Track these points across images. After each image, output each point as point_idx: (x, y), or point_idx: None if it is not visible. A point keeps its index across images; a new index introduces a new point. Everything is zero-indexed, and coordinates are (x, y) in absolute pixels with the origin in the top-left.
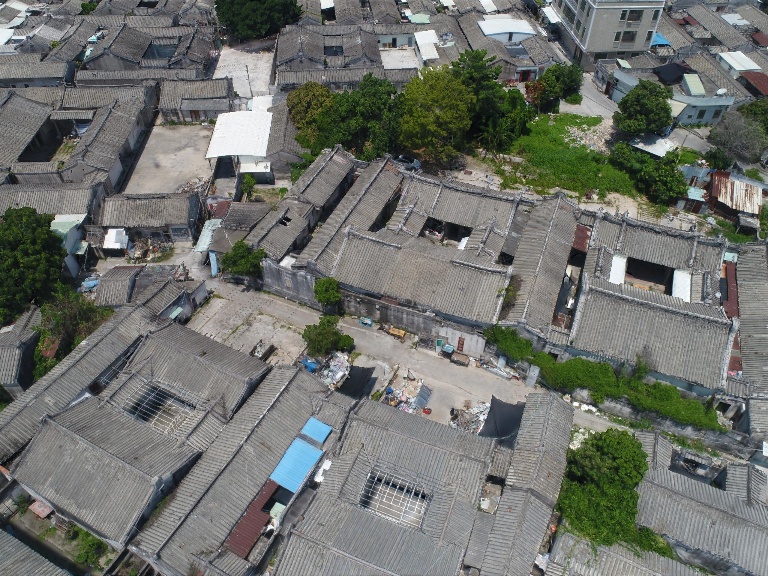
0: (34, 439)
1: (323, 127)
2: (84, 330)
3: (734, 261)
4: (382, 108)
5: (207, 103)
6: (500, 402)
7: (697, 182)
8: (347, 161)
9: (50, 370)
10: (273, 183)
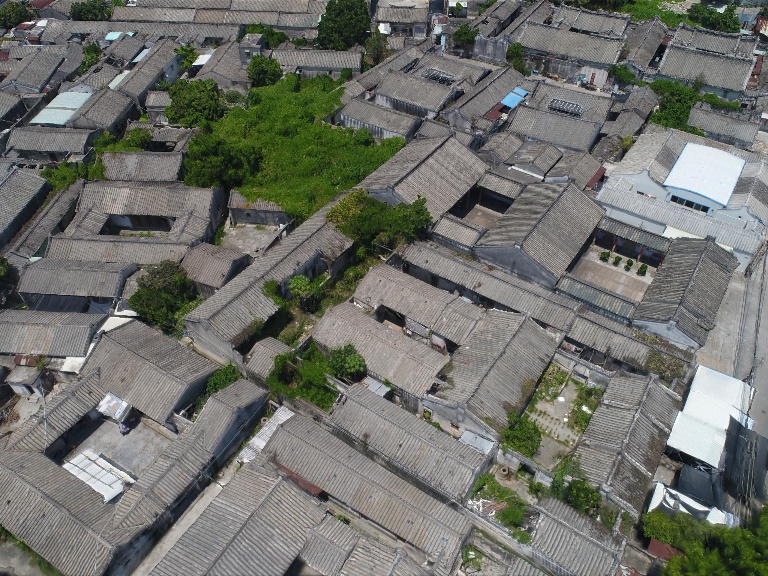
0: (385, 78)
1: None
2: (385, 56)
3: (763, 54)
4: None
5: None
6: (617, 94)
7: (747, 26)
8: (517, 2)
9: None
10: (466, 17)
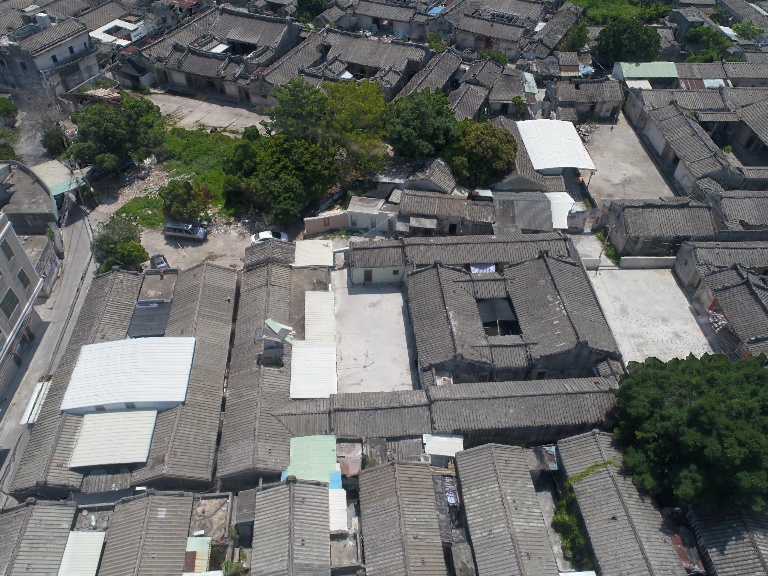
0: None
1: None
2: None
3: None
4: None
5: None
6: None
7: None
8: None
9: None
10: None
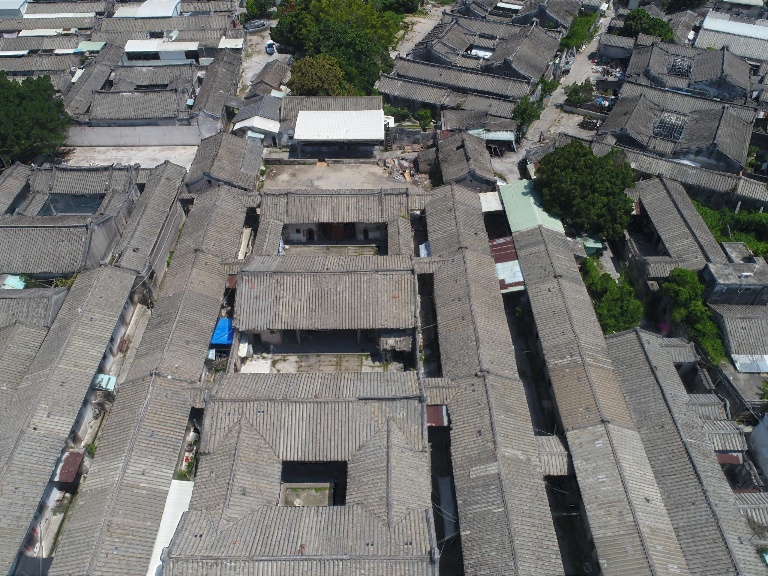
0: (725, 152)
1: None
2: None
3: None
4: None
5: (250, 157)
6: (603, 53)
7: None
8: None
9: None
10: None
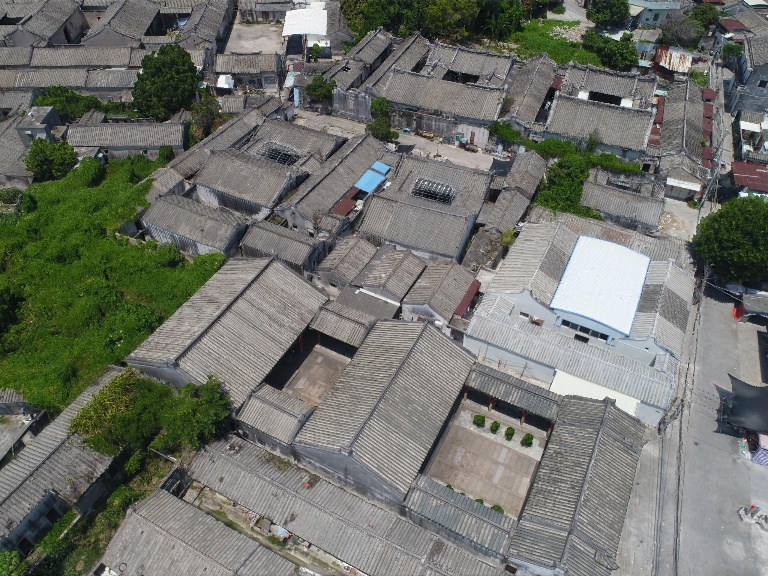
0: (206, 162)
1: (368, 15)
2: (218, 123)
3: (664, 95)
4: (413, 1)
5: (275, 6)
6: (499, 161)
7: (646, 56)
8: (387, 38)
9: (202, 140)
10: (331, 58)
